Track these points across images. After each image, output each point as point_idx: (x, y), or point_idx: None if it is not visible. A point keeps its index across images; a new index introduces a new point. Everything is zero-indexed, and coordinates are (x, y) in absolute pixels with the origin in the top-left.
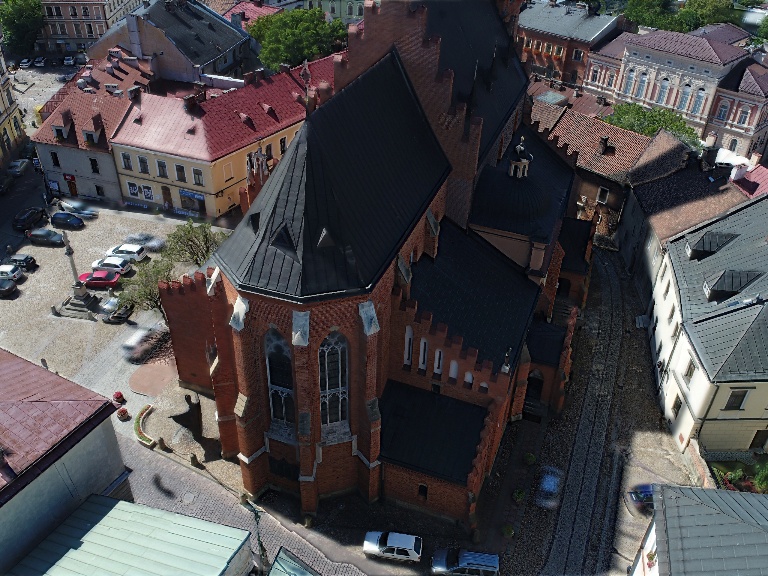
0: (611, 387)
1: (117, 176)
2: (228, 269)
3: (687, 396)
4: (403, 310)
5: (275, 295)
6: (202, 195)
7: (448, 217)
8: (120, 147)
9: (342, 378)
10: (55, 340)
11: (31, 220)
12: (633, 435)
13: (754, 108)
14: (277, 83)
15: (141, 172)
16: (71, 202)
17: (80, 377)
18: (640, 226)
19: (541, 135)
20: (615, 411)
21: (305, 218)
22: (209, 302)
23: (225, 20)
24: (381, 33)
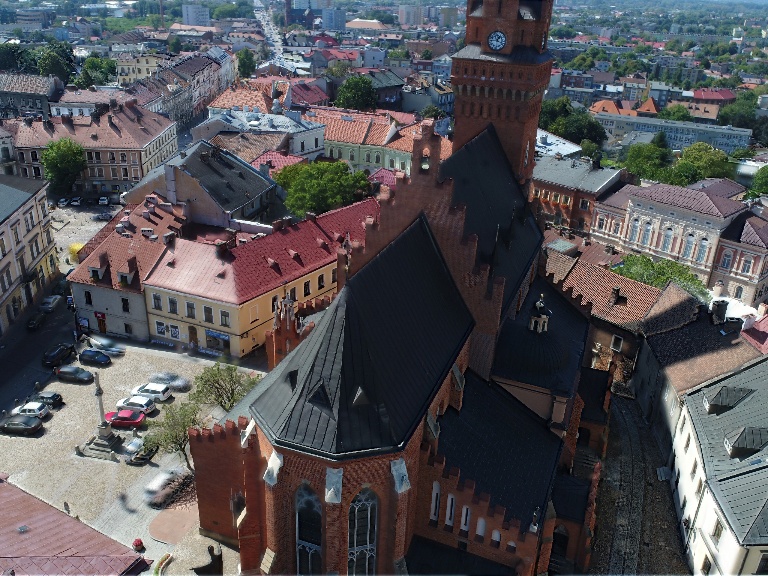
0: (637, 544)
1: (146, 315)
2: (265, 423)
3: (716, 558)
4: (431, 465)
5: (310, 452)
6: (227, 336)
7: (471, 369)
8: (152, 288)
9: (370, 535)
10: (77, 481)
11: (60, 356)
12: None
13: (757, 258)
14: (303, 230)
15: (170, 312)
16: (99, 339)
17: (100, 522)
18: (656, 376)
19: (556, 286)
20: (643, 571)
21: (342, 377)
22: (238, 450)
23: (254, 169)
24: (411, 200)
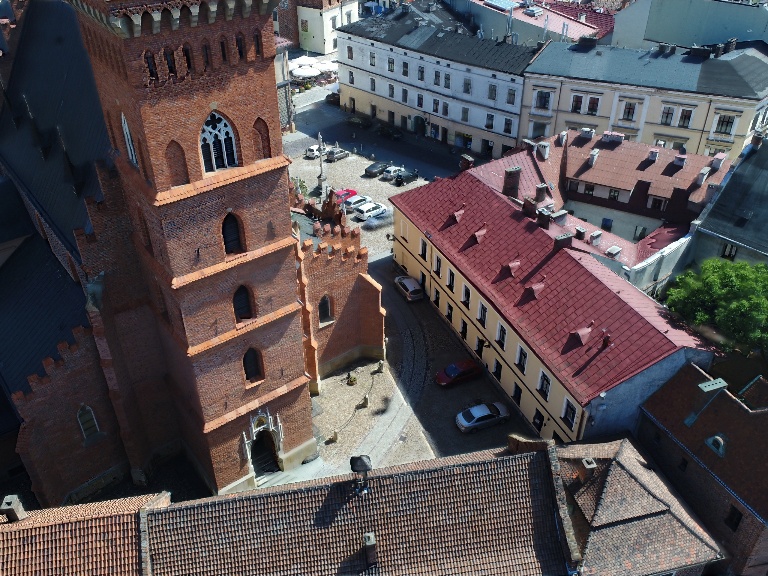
0: None
1: None
2: None
3: None
4: None
5: None
6: None
7: None
8: None
9: None
10: None
11: None
12: None
13: None
14: (531, 238)
15: None
16: None
17: None
18: None
19: None
20: None
21: None
22: None
23: None
24: None
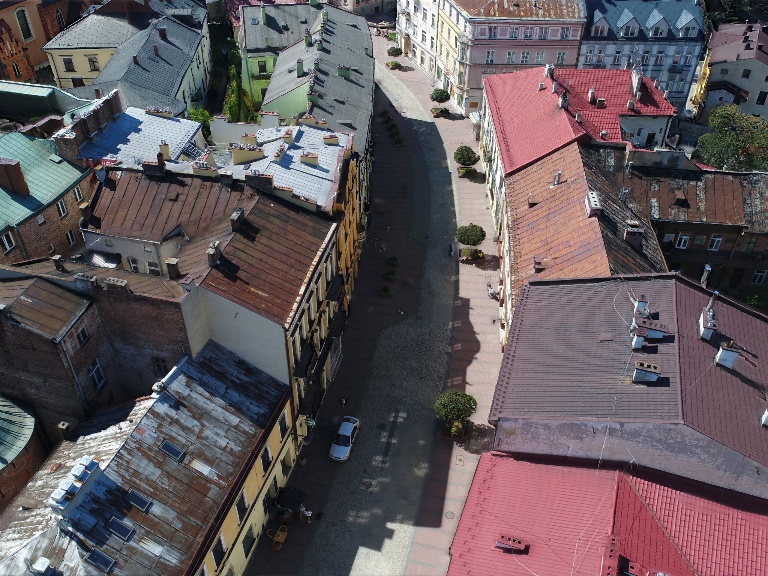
0: None
1: None
2: None
3: None
4: None
5: None
6: None
7: None
8: None
9: None
10: None
11: None
12: None
13: None
14: None
15: None
16: None
17: None
18: None
19: None
20: None
21: None
22: None
23: None
24: None
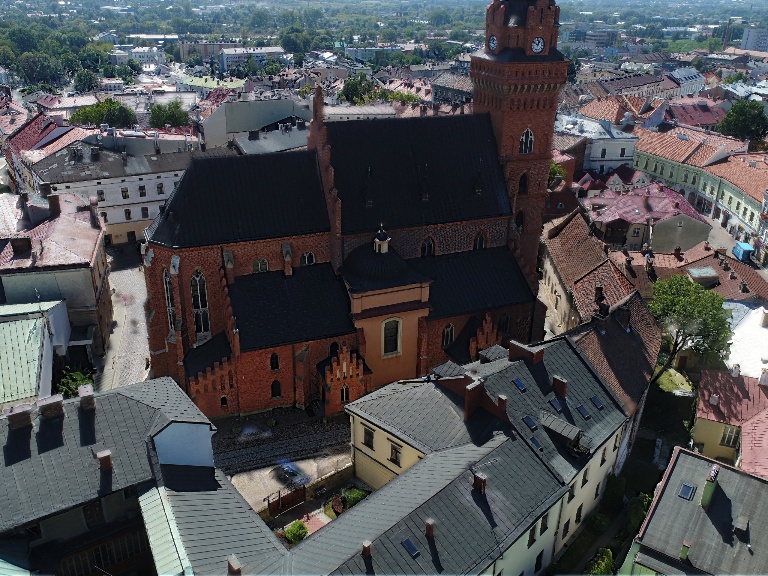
0: None
1: None
2: None
3: None
4: None
5: None
6: None
7: None
8: None
9: None
10: None
11: None
12: (346, 453)
13: None
14: None
15: None
16: None
17: None
18: None
19: (518, 260)
20: None
21: (170, 205)
22: None
23: None
24: None
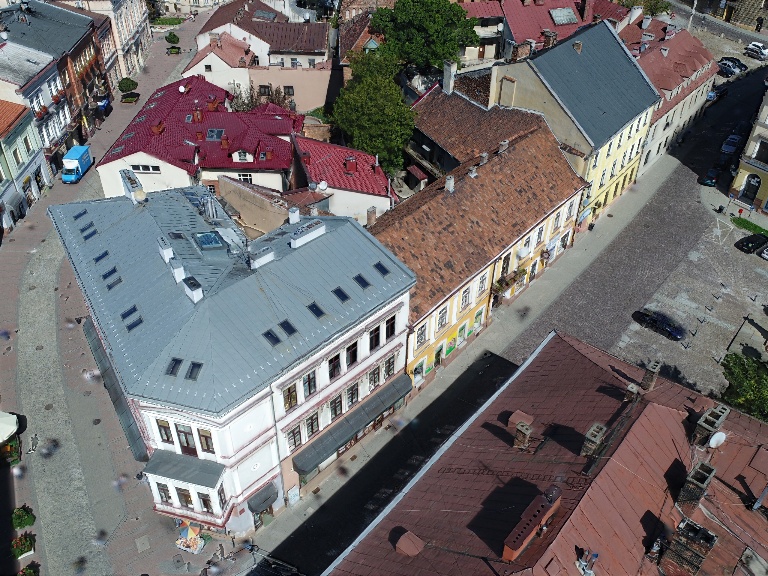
0: None
1: None
2: None
3: None
4: None
5: None
6: None
7: None
8: None
9: None
10: None
11: None
12: None
13: None
14: None
15: None
16: None
17: None
18: None
19: None
20: None
21: None
22: None
23: None
24: None
